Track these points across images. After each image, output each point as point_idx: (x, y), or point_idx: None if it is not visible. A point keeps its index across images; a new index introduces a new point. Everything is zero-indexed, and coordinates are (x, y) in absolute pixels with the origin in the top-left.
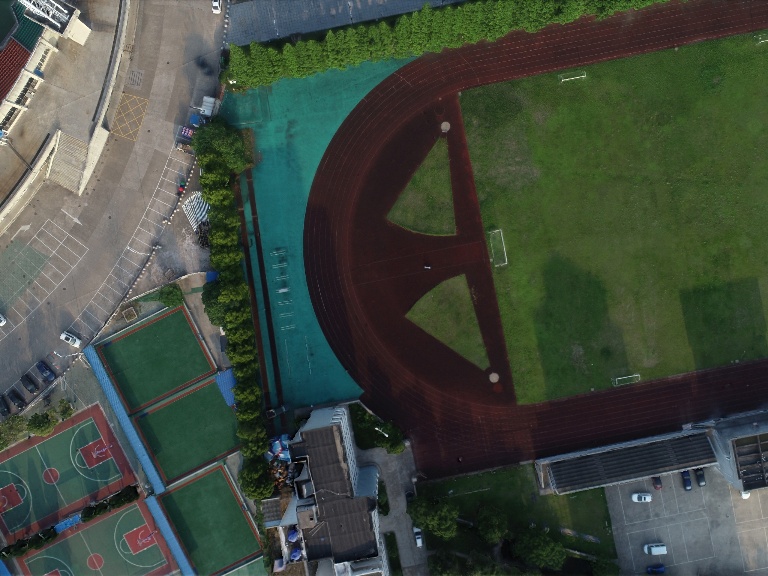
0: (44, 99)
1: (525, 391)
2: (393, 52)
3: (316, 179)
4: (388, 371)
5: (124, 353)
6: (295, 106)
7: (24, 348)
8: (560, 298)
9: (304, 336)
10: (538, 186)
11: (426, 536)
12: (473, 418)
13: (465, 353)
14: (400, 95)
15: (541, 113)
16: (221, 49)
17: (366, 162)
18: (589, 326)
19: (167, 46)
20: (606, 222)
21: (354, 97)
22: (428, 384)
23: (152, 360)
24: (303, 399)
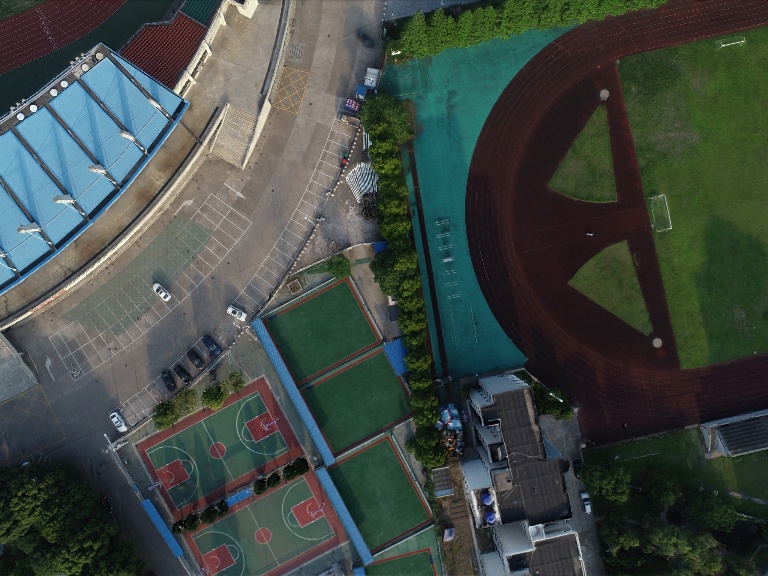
0: (212, 73)
1: (688, 355)
2: (558, 20)
3: (477, 149)
4: (552, 338)
5: (289, 326)
6: (455, 77)
7: (189, 323)
8: (721, 262)
9: (469, 305)
10: (697, 151)
11: (593, 502)
12: (637, 384)
13: (628, 319)
14: (559, 64)
15: (699, 79)
16: (381, 21)
17: (526, 131)
18: (751, 289)
19: (327, 19)
20: (766, 186)
21: (513, 67)
22: (592, 351)
23: (317, 332)
24: (468, 368)
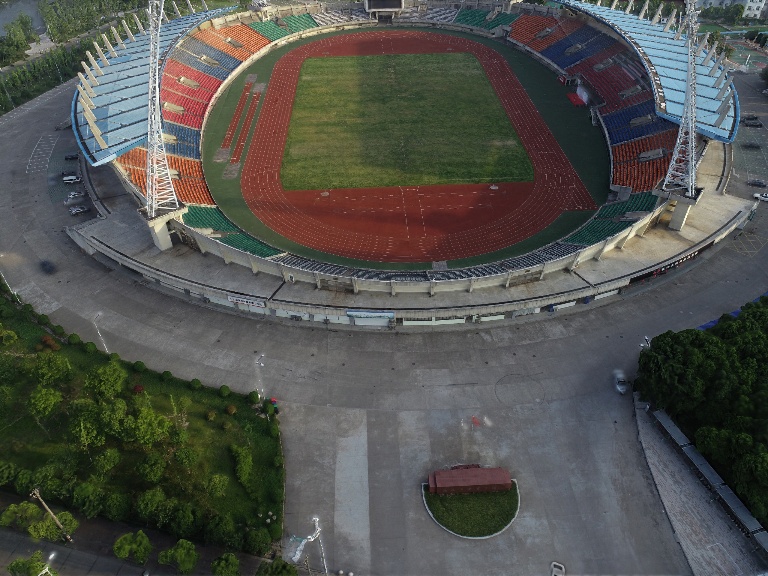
0: None
1: None
2: None
3: None
4: (676, 6)
5: None
6: None
7: None
8: None
9: None
10: None
11: None
12: None
13: None
14: None
15: None
16: None
17: None
18: None
19: None
20: None
21: None
22: None
23: None
24: None
